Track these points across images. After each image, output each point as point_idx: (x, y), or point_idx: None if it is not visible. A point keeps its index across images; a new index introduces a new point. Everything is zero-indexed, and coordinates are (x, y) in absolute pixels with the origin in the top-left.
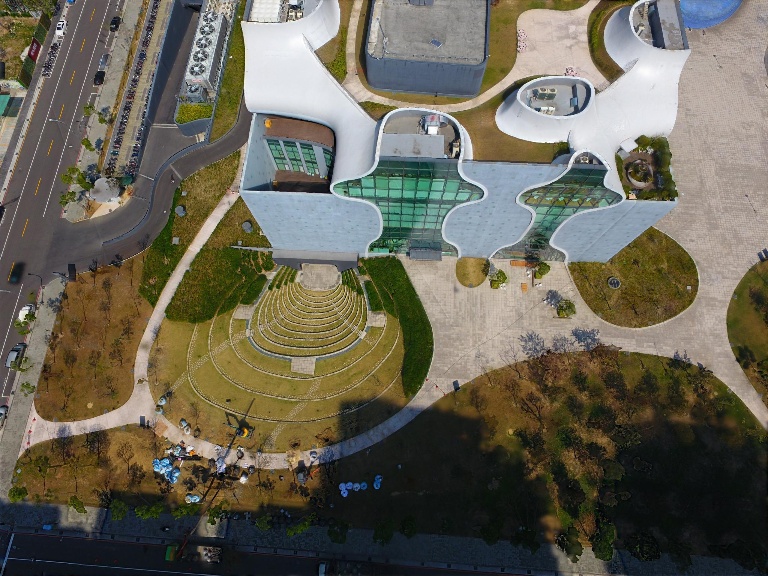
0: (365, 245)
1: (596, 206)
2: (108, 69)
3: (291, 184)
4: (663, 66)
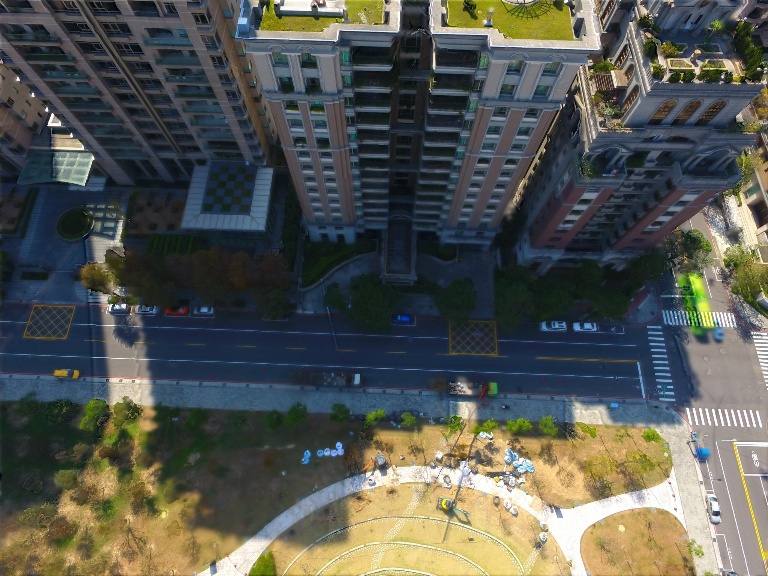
0: None
1: None
2: None
3: None
4: None
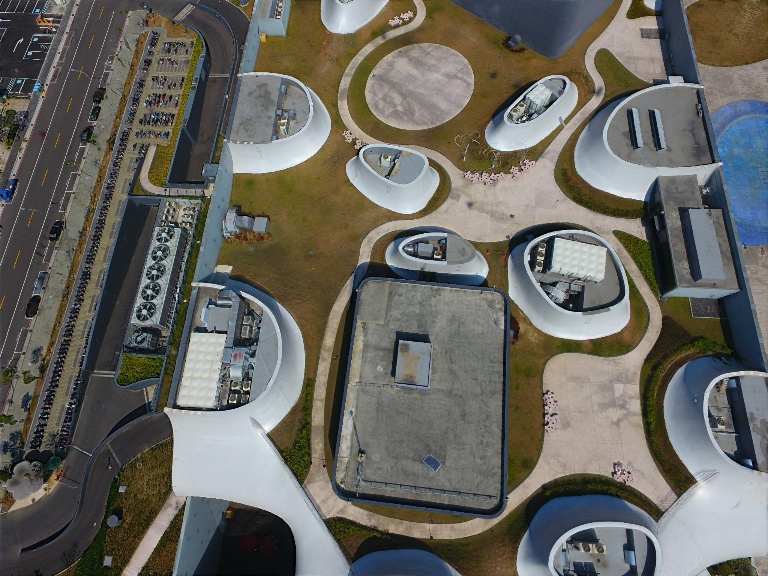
0: None
1: None
2: (44, 293)
3: (250, 512)
4: (753, 483)
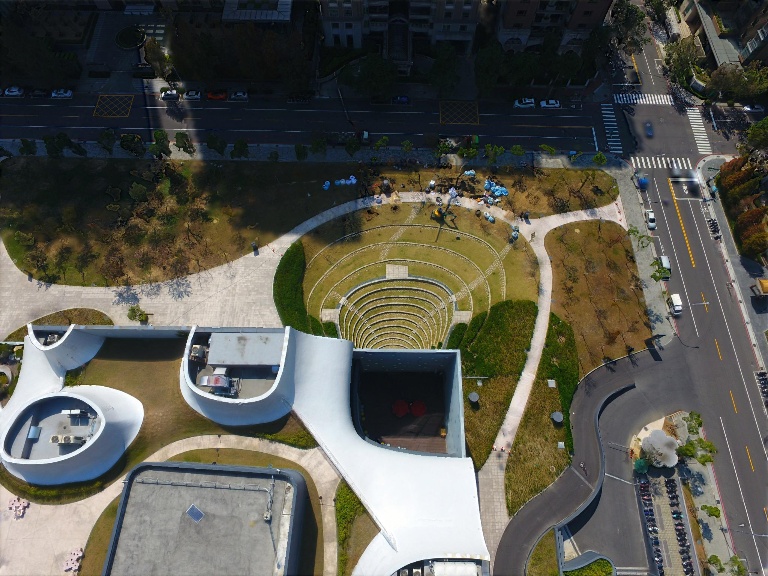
0: None
1: None
2: None
3: (425, 434)
4: None
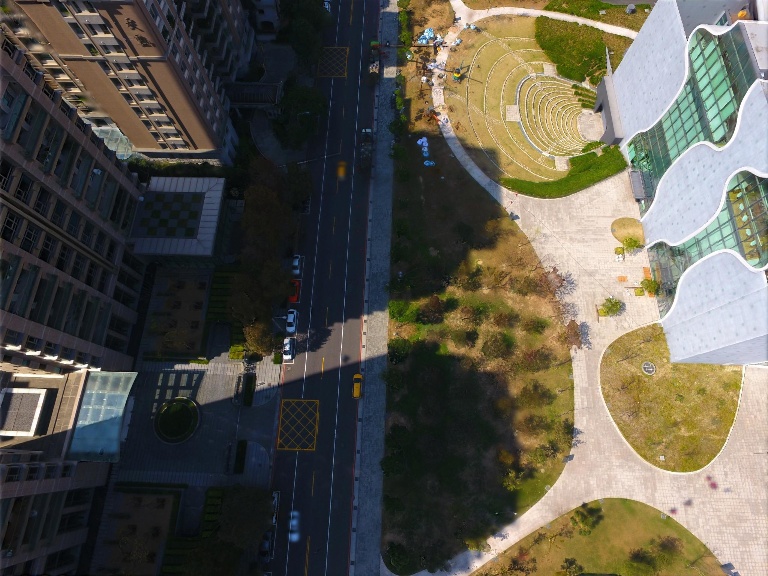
0: (635, 132)
1: (747, 258)
2: None
3: None
4: None
